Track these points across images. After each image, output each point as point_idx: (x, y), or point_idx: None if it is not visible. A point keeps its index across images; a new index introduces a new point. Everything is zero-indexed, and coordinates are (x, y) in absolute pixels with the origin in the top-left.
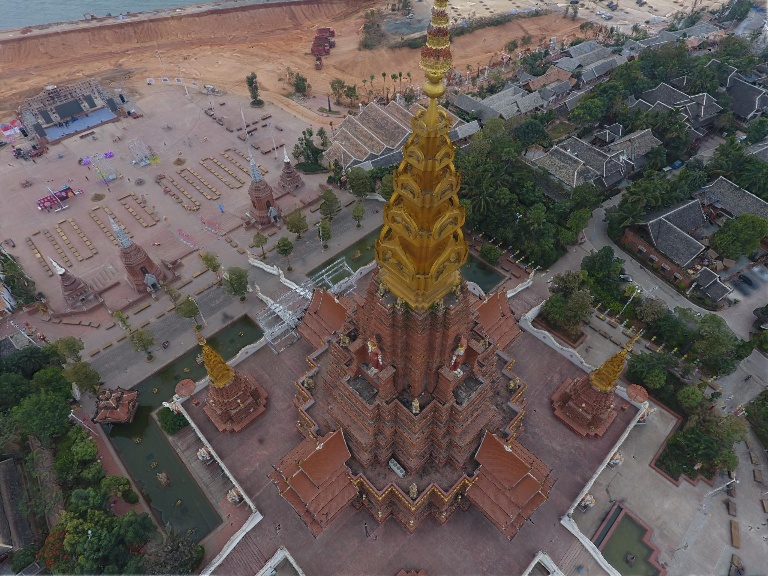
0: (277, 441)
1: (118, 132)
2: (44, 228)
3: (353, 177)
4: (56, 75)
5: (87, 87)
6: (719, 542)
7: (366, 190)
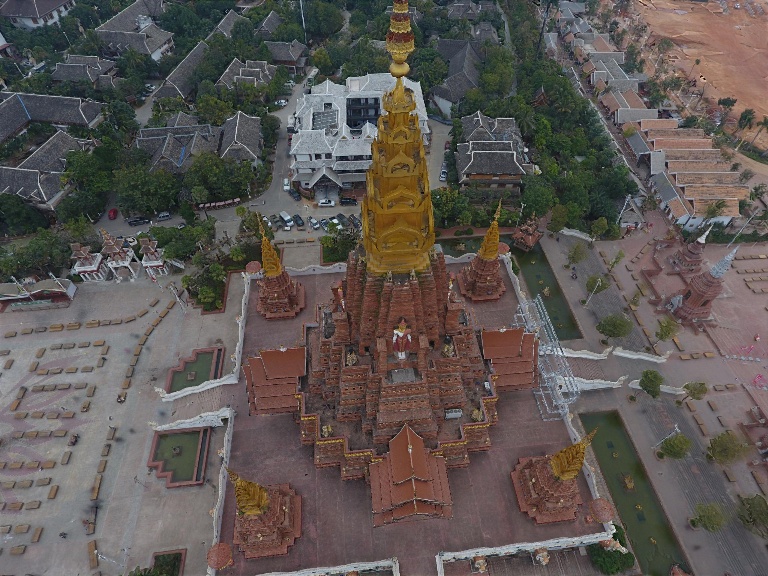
0: None
1: None
2: None
3: None
4: None
5: None
6: (107, 534)
7: None
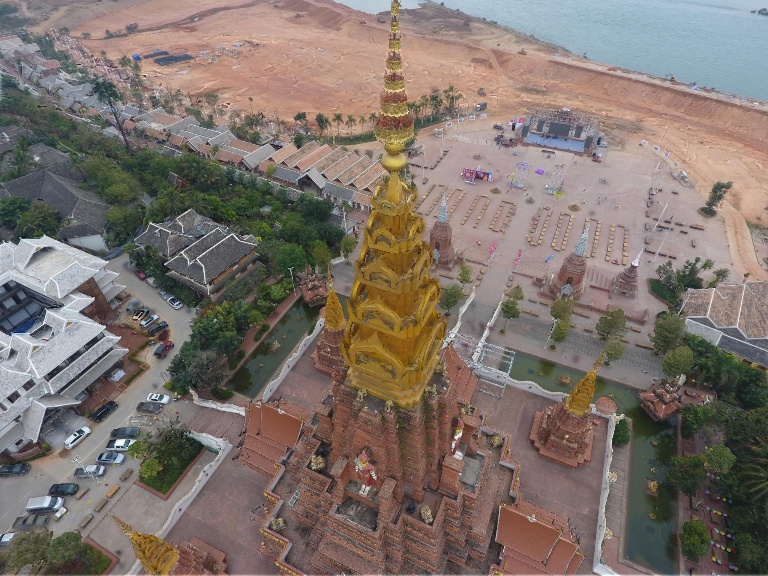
0: (318, 400)
1: (568, 162)
2: (448, 186)
3: (662, 323)
4: (590, 106)
5: (585, 120)
6: None
7: (666, 347)
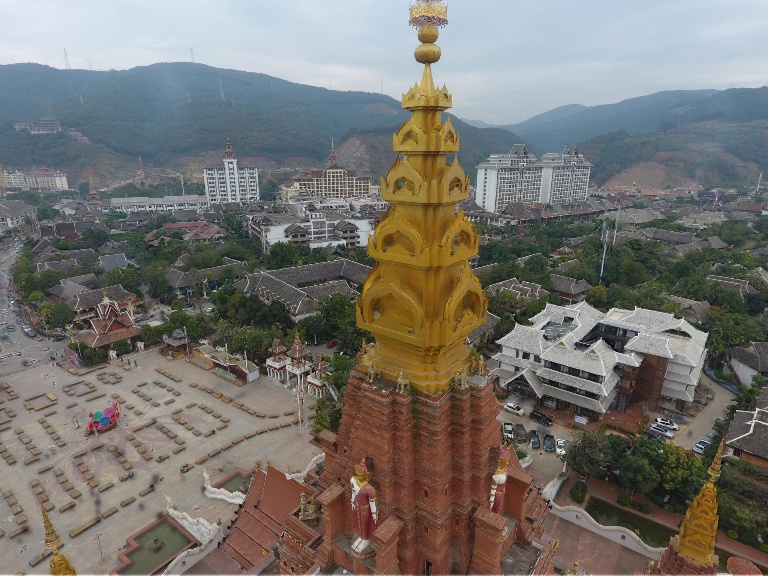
0: None
1: None
2: None
3: None
4: None
5: None
6: None
7: None
